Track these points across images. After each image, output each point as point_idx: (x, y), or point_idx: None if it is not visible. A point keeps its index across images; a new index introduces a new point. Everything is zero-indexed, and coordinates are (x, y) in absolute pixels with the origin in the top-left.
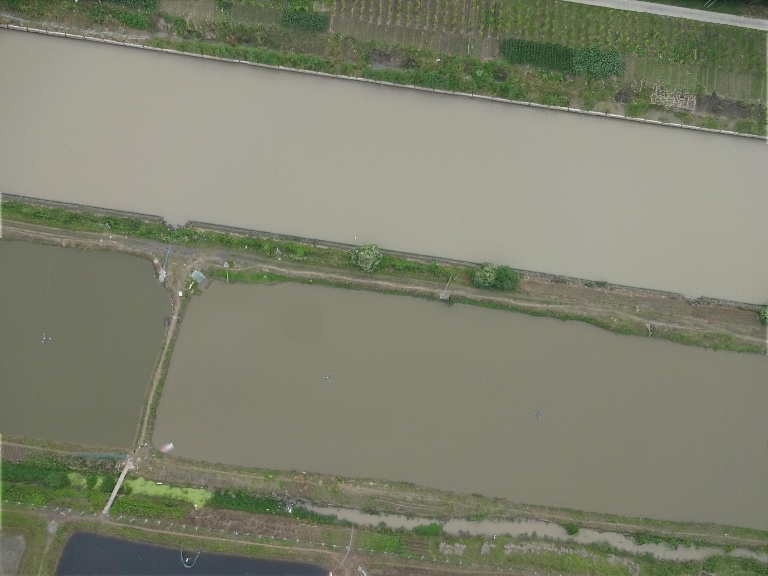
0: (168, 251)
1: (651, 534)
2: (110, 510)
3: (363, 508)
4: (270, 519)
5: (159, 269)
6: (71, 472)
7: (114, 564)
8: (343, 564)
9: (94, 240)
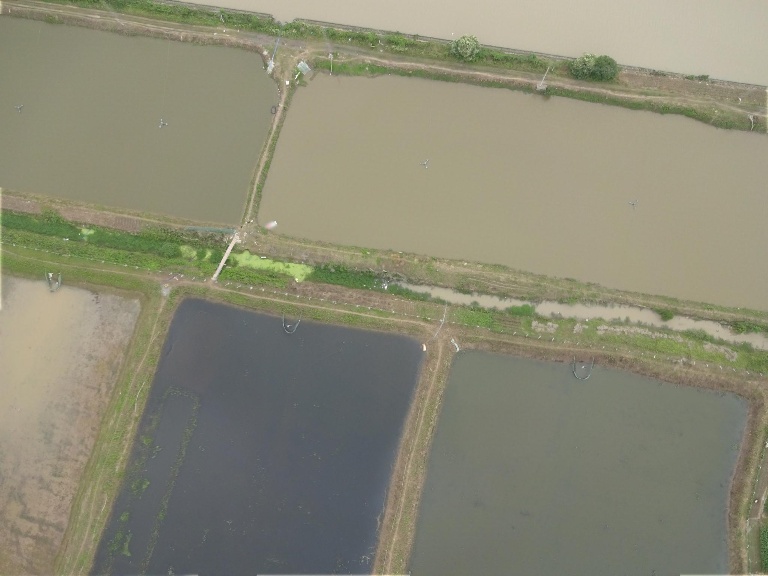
0: (277, 43)
1: (750, 322)
2: (218, 277)
3: (457, 286)
4: (367, 293)
5: (268, 60)
6: (183, 245)
7: (221, 328)
8: (437, 336)
9: (209, 33)
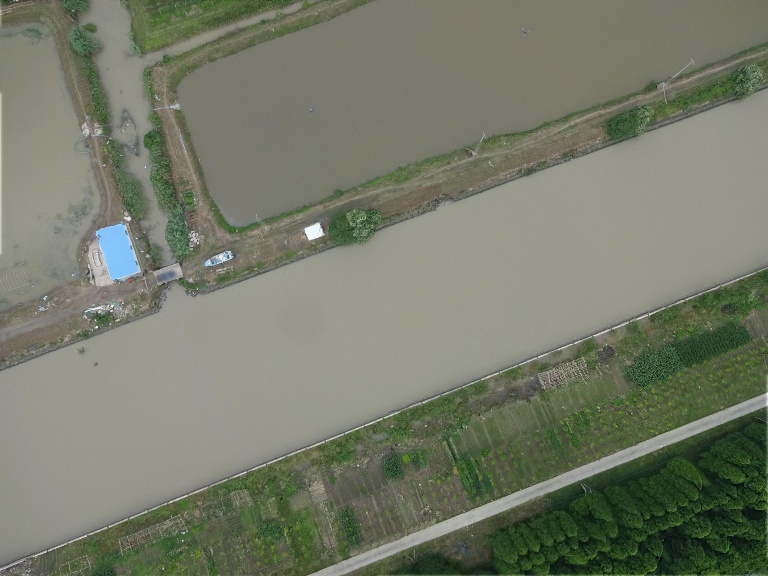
0: None
1: None
2: None
3: None
4: None
5: None
6: None
7: None
8: None
9: None
